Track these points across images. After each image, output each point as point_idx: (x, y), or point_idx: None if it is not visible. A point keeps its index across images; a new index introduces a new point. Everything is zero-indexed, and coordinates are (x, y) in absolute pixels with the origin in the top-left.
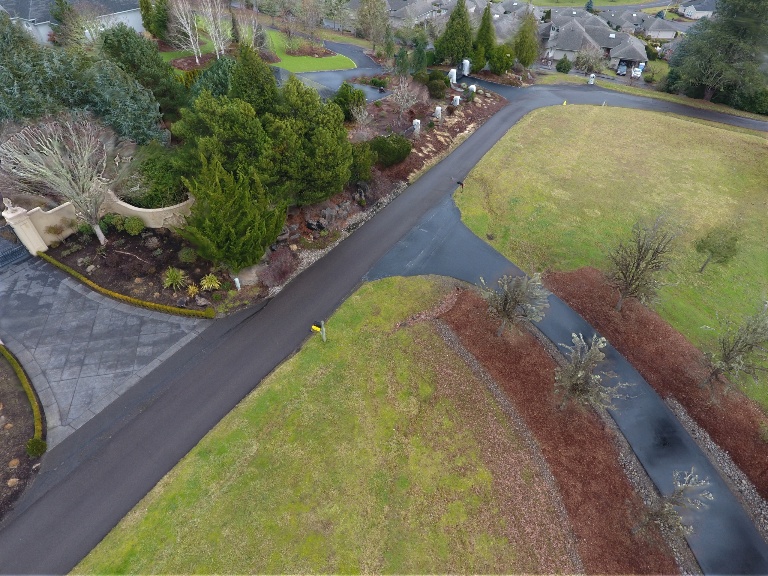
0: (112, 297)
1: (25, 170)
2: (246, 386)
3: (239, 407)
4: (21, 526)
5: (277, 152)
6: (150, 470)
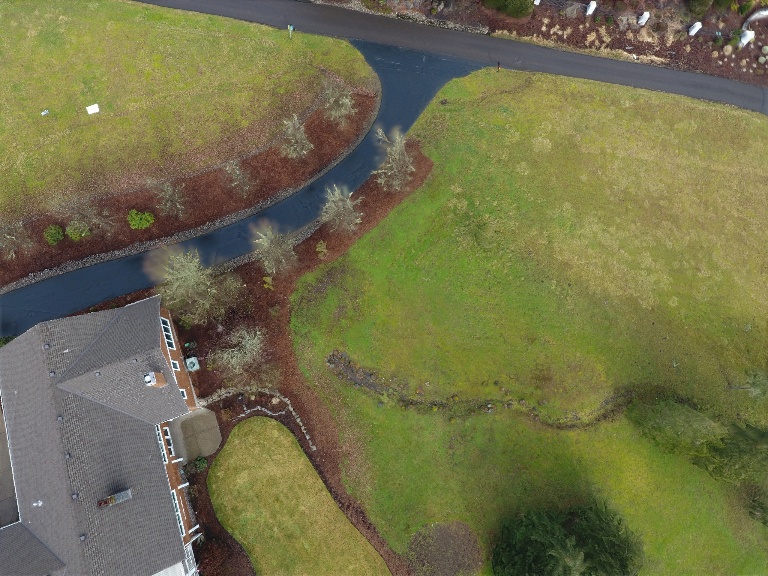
0: None
1: None
2: (248, 18)
3: (236, 20)
4: None
5: None
6: (197, 6)
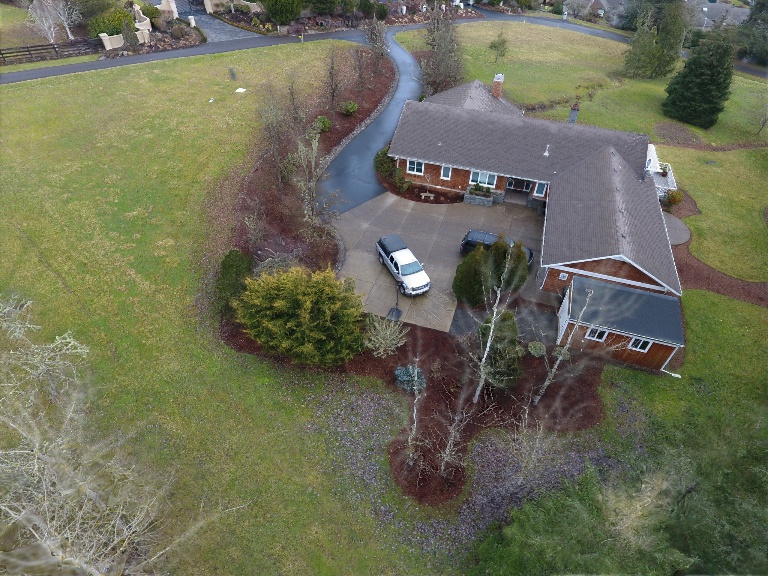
0: (233, 25)
1: None
2: None
3: (265, 46)
4: None
5: None
6: None
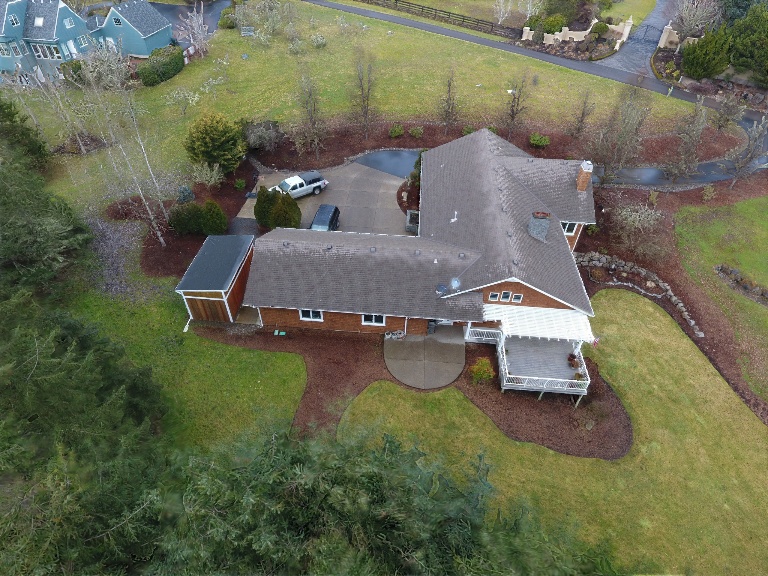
0: None
1: (681, 8)
2: (632, 84)
3: None
4: (571, 61)
5: (760, 42)
6: None
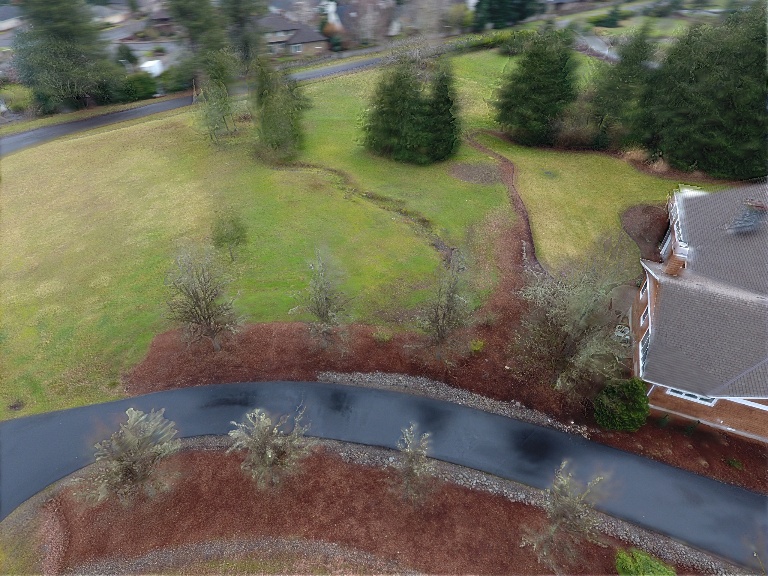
0: None
1: None
2: None
3: None
4: None
5: None
6: None
